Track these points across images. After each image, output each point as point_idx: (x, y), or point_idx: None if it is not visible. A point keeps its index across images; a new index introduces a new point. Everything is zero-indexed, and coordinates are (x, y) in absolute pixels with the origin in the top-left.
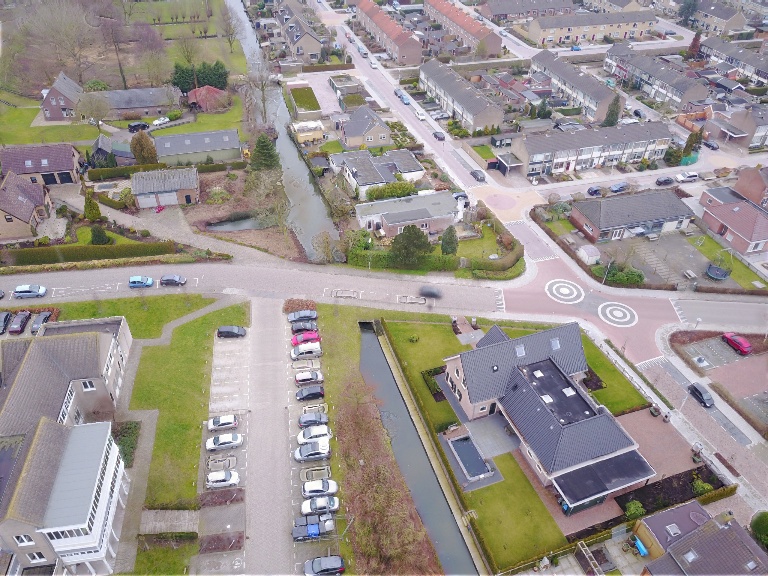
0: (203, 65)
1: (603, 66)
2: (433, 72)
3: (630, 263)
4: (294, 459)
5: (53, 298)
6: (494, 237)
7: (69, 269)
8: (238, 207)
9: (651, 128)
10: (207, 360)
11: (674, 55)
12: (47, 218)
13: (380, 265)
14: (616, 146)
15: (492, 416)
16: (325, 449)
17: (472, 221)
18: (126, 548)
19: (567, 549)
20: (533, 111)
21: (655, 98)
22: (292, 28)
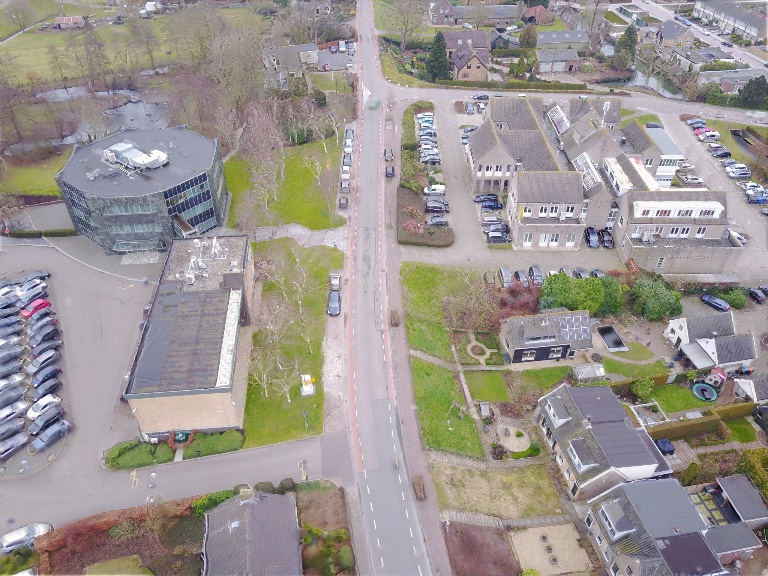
0: None
1: None
2: (711, 2)
3: None
4: (729, 177)
5: None
6: None
7: (535, 92)
8: (605, 75)
9: None
10: None
11: None
12: None
13: (730, 104)
14: None
15: None
16: None
17: None
18: None
19: None
20: None
21: None
22: None
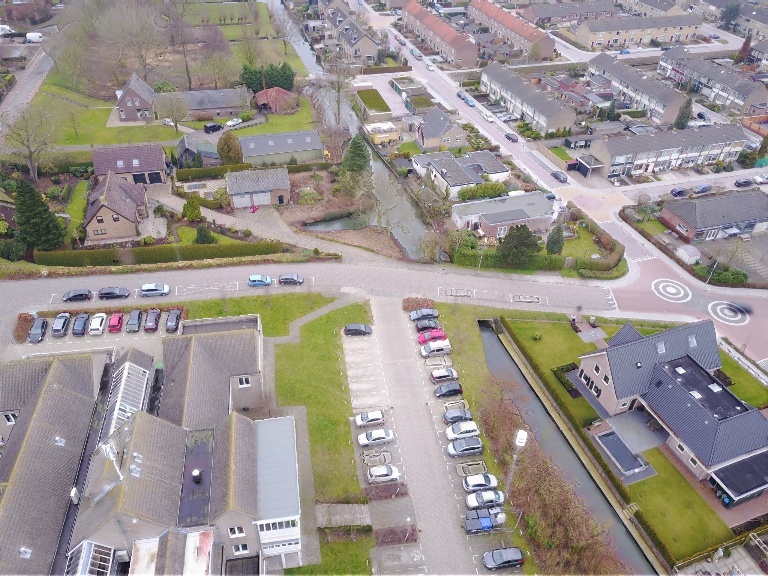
0: (270, 67)
1: (657, 69)
2: (497, 74)
3: (734, 263)
4: (448, 454)
5: (177, 296)
6: (590, 237)
7: (186, 268)
8: (331, 207)
9: (726, 130)
10: (340, 357)
11: (725, 59)
12: (146, 218)
13: (487, 264)
14: (694, 148)
15: (631, 412)
16: (523, 442)
17: (565, 221)
18: (308, 541)
19: (737, 541)
20: (603, 113)
21: (715, 101)
22: (348, 30)
